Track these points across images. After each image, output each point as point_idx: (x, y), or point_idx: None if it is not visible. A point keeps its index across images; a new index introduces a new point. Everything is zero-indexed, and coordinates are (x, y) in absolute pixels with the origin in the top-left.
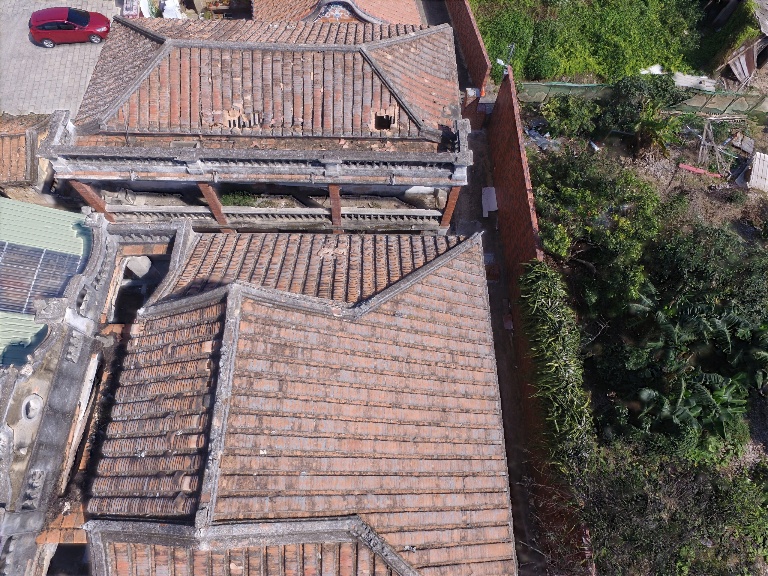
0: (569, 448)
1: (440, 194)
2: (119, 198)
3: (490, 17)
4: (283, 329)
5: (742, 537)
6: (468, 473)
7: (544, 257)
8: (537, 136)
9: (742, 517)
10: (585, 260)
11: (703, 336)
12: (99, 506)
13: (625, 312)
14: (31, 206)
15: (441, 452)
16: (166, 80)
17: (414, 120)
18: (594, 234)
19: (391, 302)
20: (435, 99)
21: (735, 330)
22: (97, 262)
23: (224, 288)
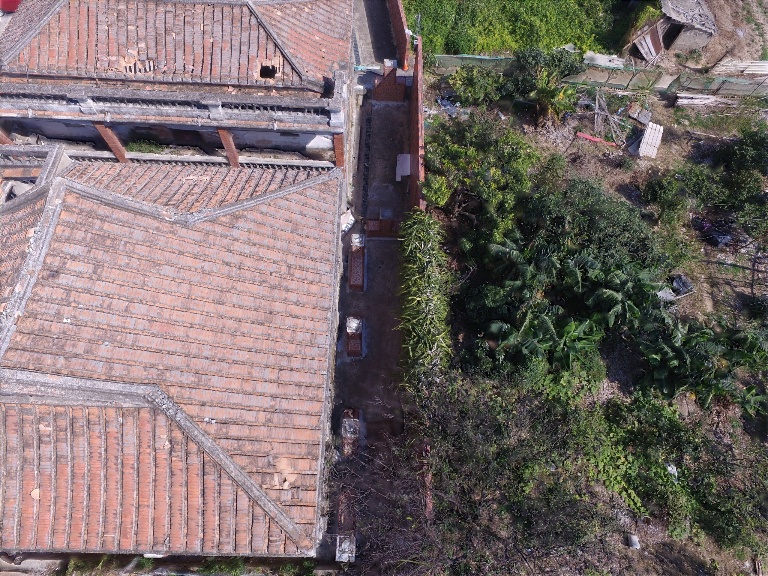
0: (421, 372)
1: None
2: (29, 141)
3: None
4: (107, 223)
5: (584, 462)
6: (286, 368)
7: (437, 212)
8: (448, 105)
9: (577, 439)
10: None
11: (552, 273)
12: None
13: (493, 256)
14: None
15: (259, 346)
16: (65, 26)
17: (296, 70)
18: (472, 185)
19: (231, 216)
20: (324, 55)
21: (586, 270)
22: None
23: (51, 181)
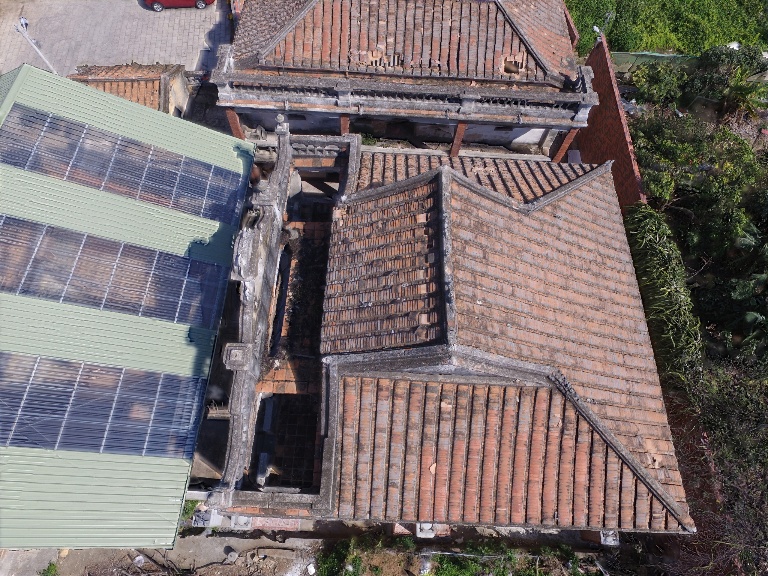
0: (684, 362)
1: (545, 144)
2: (257, 133)
3: None
4: (480, 210)
5: None
6: (625, 353)
7: None
8: (623, 102)
9: None
10: None
11: None
12: (332, 346)
13: (727, 249)
14: (200, 127)
15: (604, 331)
16: (320, 21)
17: (541, 65)
18: (695, 180)
19: (551, 206)
20: (554, 51)
21: None
22: (284, 166)
23: (436, 170)
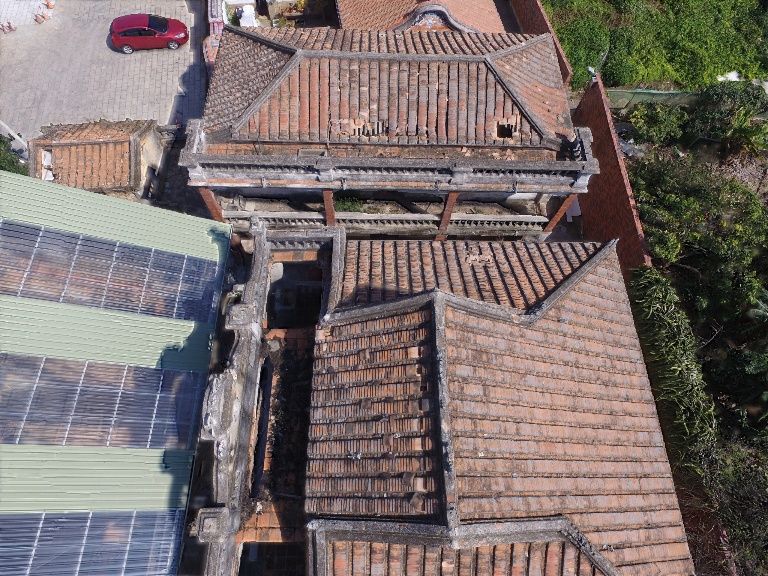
0: (699, 450)
1: (542, 200)
2: (235, 204)
3: (565, 24)
4: (478, 335)
5: None
6: (641, 475)
7: None
8: (621, 142)
9: None
10: (686, 265)
11: None
12: (318, 506)
13: (739, 317)
14: (170, 213)
15: (617, 454)
16: (296, 90)
17: (537, 129)
18: (703, 240)
19: (554, 308)
20: (549, 108)
21: None
22: (261, 269)
23: (427, 296)
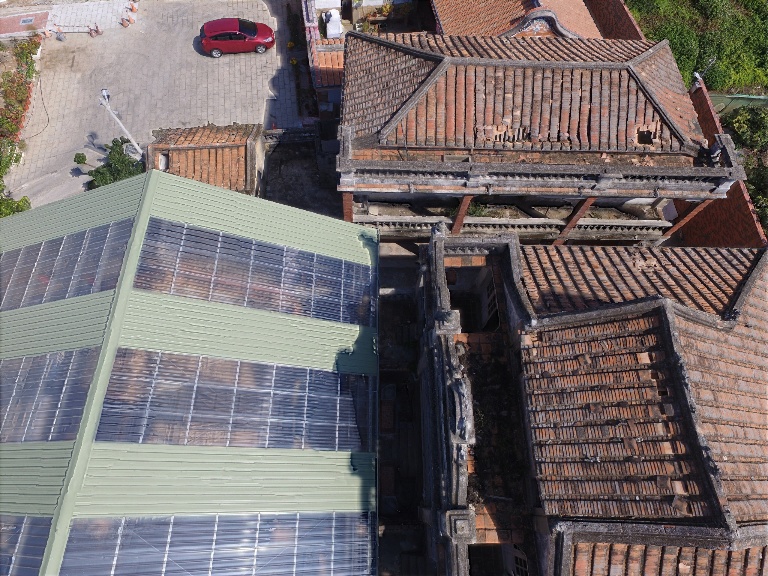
0: None
1: (659, 205)
2: (365, 208)
3: (652, 29)
4: (698, 341)
5: None
6: None
7: None
8: None
9: None
10: None
11: None
12: (560, 508)
13: None
14: (324, 218)
15: None
16: (443, 96)
17: (678, 135)
18: None
19: None
20: (681, 114)
21: None
22: None
23: (655, 302)
